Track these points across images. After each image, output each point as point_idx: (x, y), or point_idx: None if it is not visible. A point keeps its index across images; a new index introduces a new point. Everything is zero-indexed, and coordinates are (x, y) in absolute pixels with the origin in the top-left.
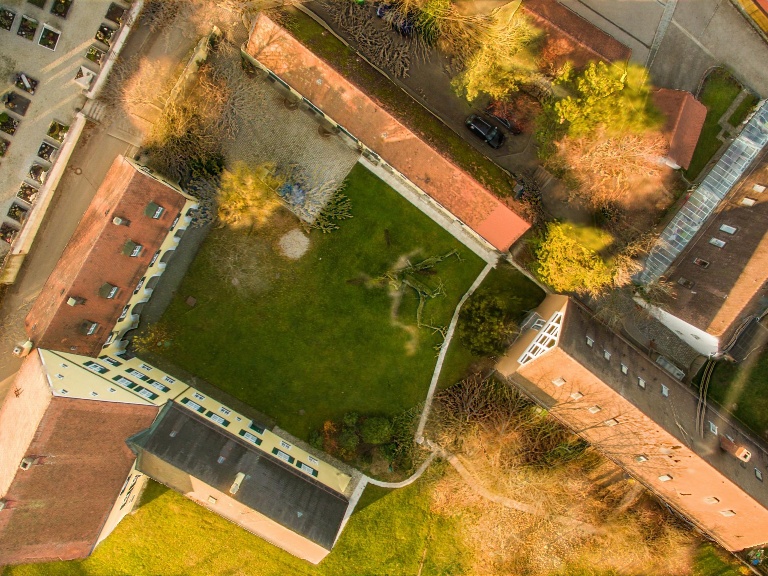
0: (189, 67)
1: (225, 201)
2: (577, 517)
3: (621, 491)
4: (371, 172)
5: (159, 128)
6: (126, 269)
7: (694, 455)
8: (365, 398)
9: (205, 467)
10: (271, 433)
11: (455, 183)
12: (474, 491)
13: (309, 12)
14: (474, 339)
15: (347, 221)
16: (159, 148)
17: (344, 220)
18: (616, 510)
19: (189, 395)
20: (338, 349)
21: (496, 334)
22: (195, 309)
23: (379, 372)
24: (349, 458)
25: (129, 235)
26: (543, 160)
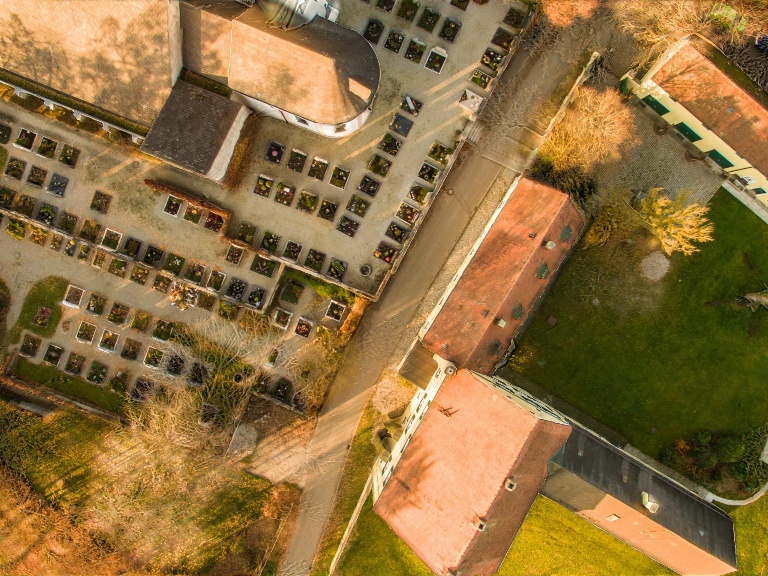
0: (574, 92)
1: (595, 223)
2: None
3: None
4: (734, 197)
5: (544, 151)
6: (532, 291)
7: None
8: (715, 417)
9: (616, 486)
10: None
11: None
12: None
13: (710, 42)
14: None
15: (708, 244)
16: (546, 171)
17: (705, 243)
18: None
19: None
20: (693, 369)
21: None
22: (555, 328)
23: (731, 392)
24: None
25: (544, 258)
26: None
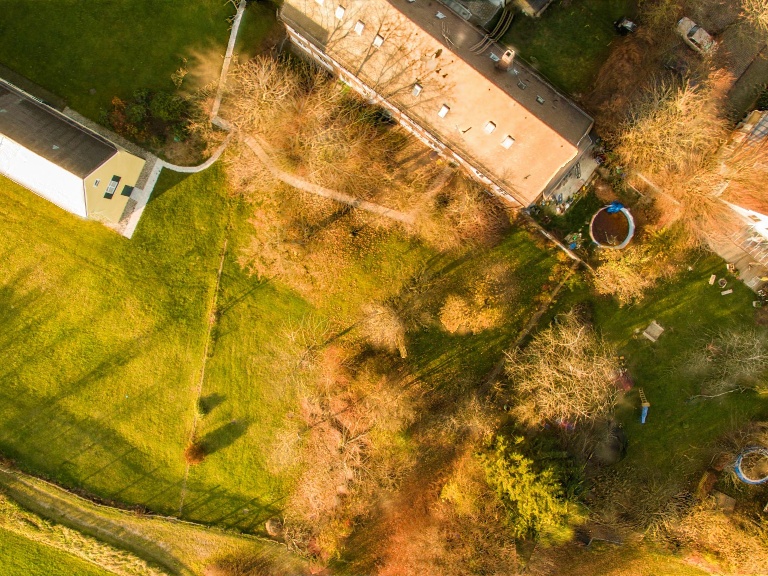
0: None
1: None
2: (383, 203)
3: (429, 175)
4: None
5: None
6: None
7: (455, 57)
8: (157, 75)
9: None
10: None
11: None
12: (274, 176)
13: None
14: None
15: None
16: None
17: None
18: (424, 195)
19: None
20: (127, 23)
21: None
22: None
23: (170, 47)
24: (142, 139)
25: None
26: None
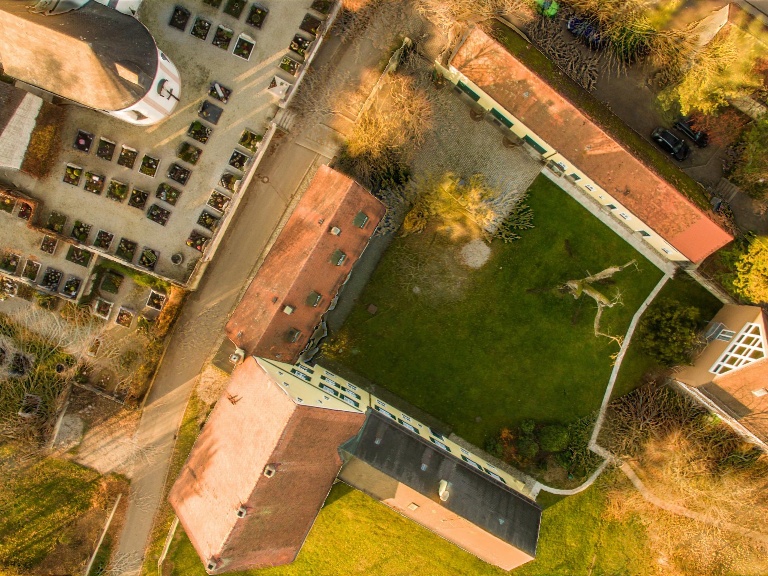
0: (383, 78)
1: None
2: (745, 525)
3: None
4: (553, 183)
5: (353, 138)
6: (330, 278)
7: None
8: (541, 406)
9: (411, 474)
10: (448, 440)
11: (657, 195)
12: (645, 498)
13: (511, 25)
14: (666, 349)
15: (528, 231)
16: (354, 158)
17: (525, 230)
18: None
19: (376, 402)
20: (516, 357)
21: (689, 344)
22: (376, 317)
23: (555, 380)
24: (524, 465)
25: (338, 244)
26: (728, 173)
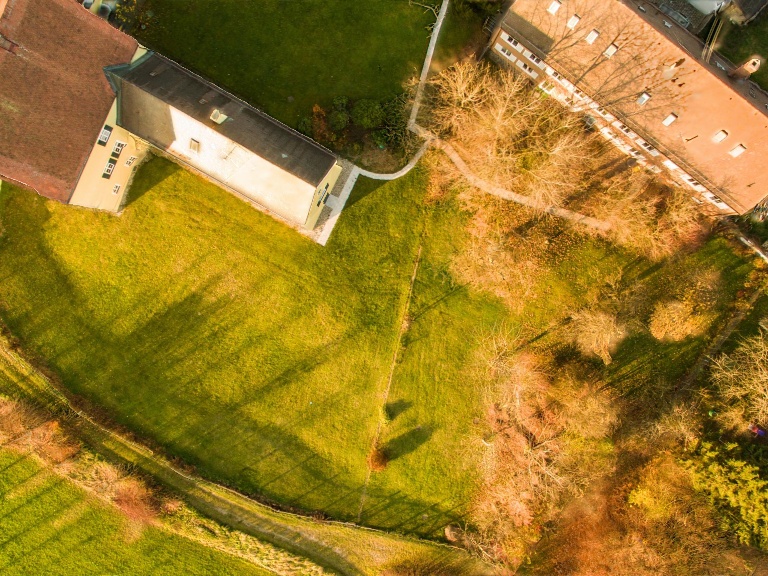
0: None
1: None
2: (579, 210)
3: (625, 182)
4: None
5: None
6: None
7: (699, 67)
8: (355, 83)
9: (186, 103)
10: None
11: None
12: (470, 183)
13: None
14: None
15: None
16: None
17: None
18: (620, 202)
19: None
20: (327, 30)
21: None
22: None
23: (369, 55)
24: (339, 147)
25: None
26: None
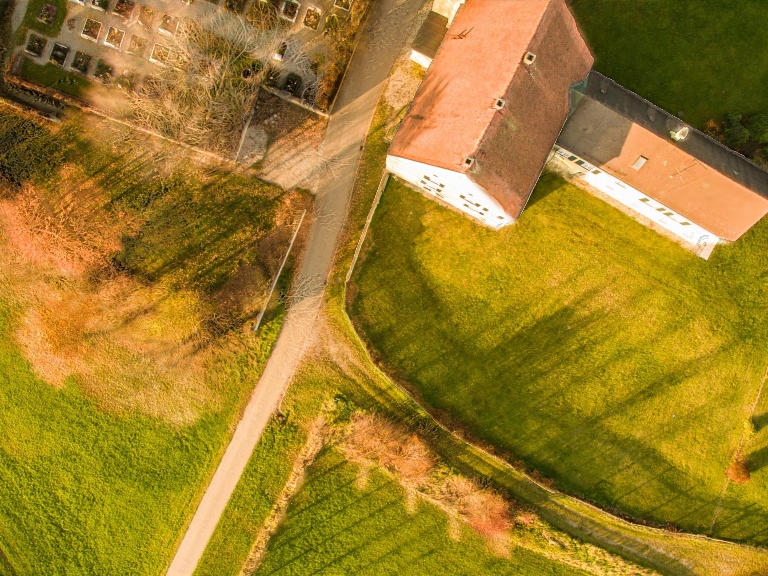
0: None
1: None
2: None
3: None
4: None
5: None
6: None
7: None
8: (746, 98)
9: (642, 120)
10: None
11: None
12: None
13: None
14: None
15: None
16: None
17: None
18: None
19: None
20: (720, 46)
21: None
22: (573, 6)
23: (761, 70)
24: None
25: None
26: None
